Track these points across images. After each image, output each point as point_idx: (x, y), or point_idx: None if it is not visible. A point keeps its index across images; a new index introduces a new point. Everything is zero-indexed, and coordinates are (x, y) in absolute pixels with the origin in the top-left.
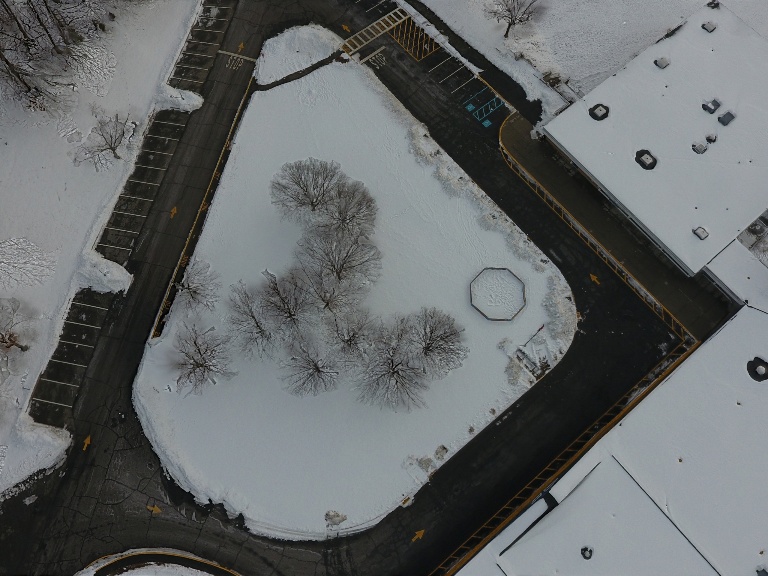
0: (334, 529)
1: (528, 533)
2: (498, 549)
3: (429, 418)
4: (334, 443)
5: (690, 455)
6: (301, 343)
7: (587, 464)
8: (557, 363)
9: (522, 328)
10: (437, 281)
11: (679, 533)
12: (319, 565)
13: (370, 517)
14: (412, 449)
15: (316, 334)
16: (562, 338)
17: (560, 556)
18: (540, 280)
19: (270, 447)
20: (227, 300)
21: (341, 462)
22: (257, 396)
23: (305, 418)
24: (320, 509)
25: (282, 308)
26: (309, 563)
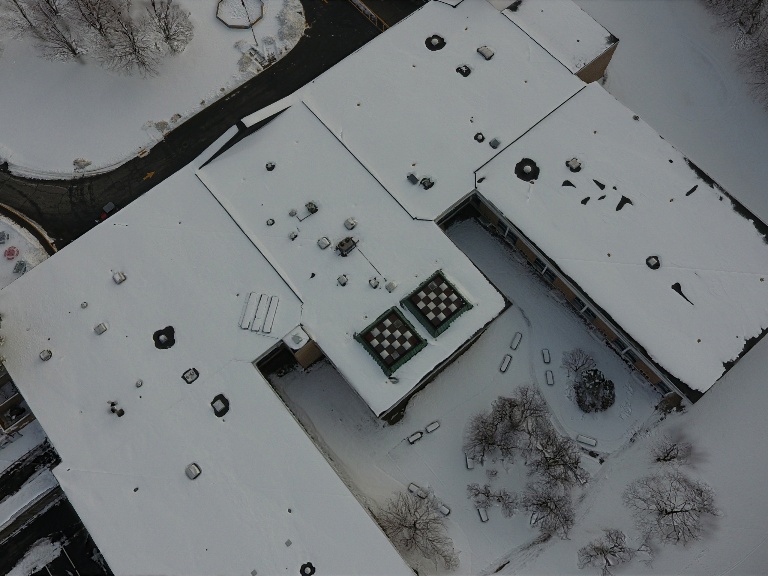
0: (80, 171)
1: (224, 153)
2: (198, 164)
3: (169, 95)
4: (88, 112)
5: (367, 101)
6: (39, 3)
7: (279, 106)
8: (282, 57)
9: (257, 33)
10: (191, 2)
11: (347, 151)
12: (65, 196)
13: (111, 162)
14: (152, 116)
15: (72, 23)
16: (289, 40)
17: (248, 169)
18: (278, 0)
19: (35, 116)
20: (4, 2)
21: (92, 125)
22: (29, 81)
23: (67, 96)
24: (71, 157)
25: (48, 6)
26: (57, 195)
